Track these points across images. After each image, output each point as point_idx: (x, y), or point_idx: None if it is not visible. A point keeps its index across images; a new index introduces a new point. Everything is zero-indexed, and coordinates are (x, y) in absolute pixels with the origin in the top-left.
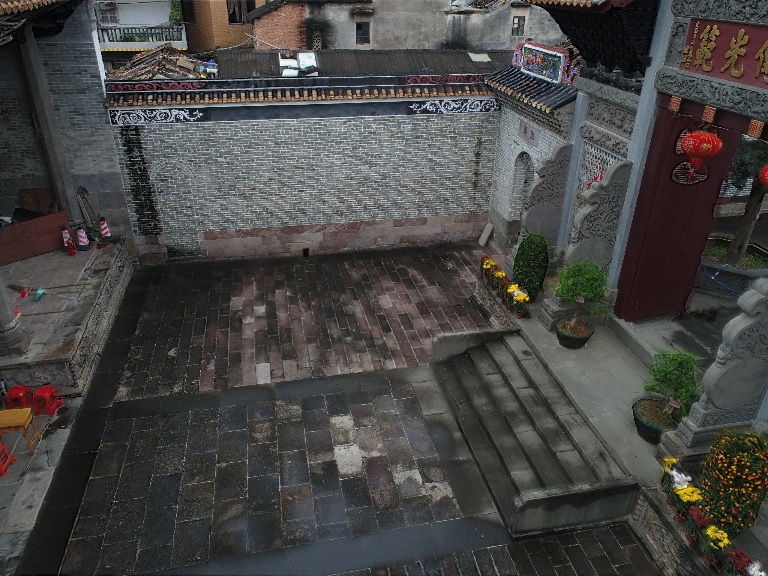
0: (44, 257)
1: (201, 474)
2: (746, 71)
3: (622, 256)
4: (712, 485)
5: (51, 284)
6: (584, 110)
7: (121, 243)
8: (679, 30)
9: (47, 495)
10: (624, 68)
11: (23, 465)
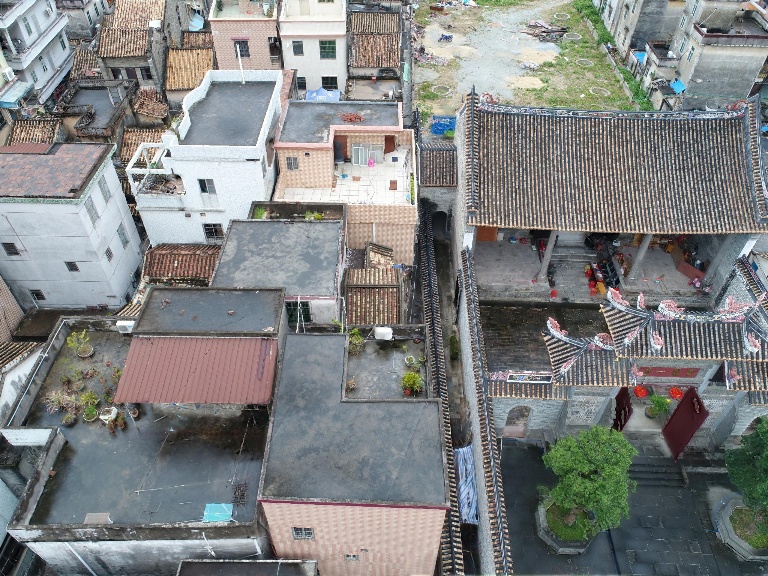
0: (686, 278)
1: (593, 329)
2: None
3: None
4: None
5: (667, 284)
6: None
7: (704, 296)
8: None
9: (585, 304)
10: None
11: (594, 298)
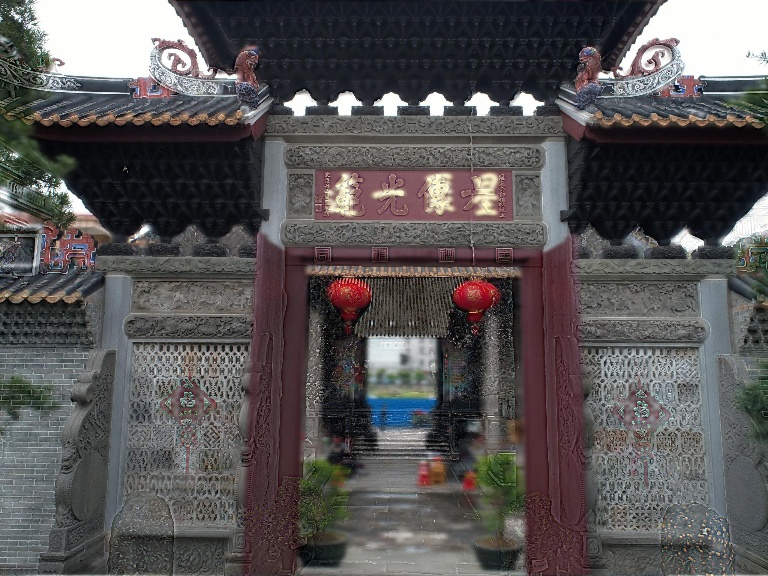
0: None
1: None
2: (411, 209)
3: (276, 473)
4: (715, 574)
5: None
6: (127, 298)
7: None
8: (300, 181)
9: None
10: (213, 230)
11: None
